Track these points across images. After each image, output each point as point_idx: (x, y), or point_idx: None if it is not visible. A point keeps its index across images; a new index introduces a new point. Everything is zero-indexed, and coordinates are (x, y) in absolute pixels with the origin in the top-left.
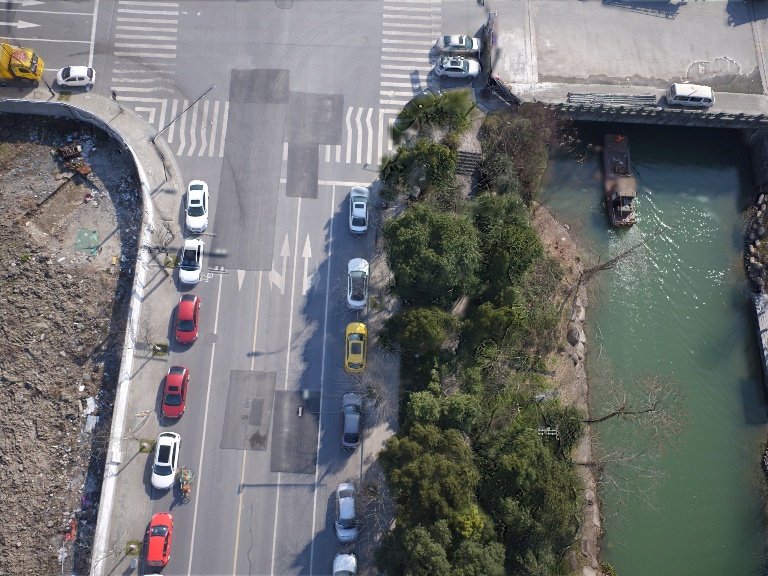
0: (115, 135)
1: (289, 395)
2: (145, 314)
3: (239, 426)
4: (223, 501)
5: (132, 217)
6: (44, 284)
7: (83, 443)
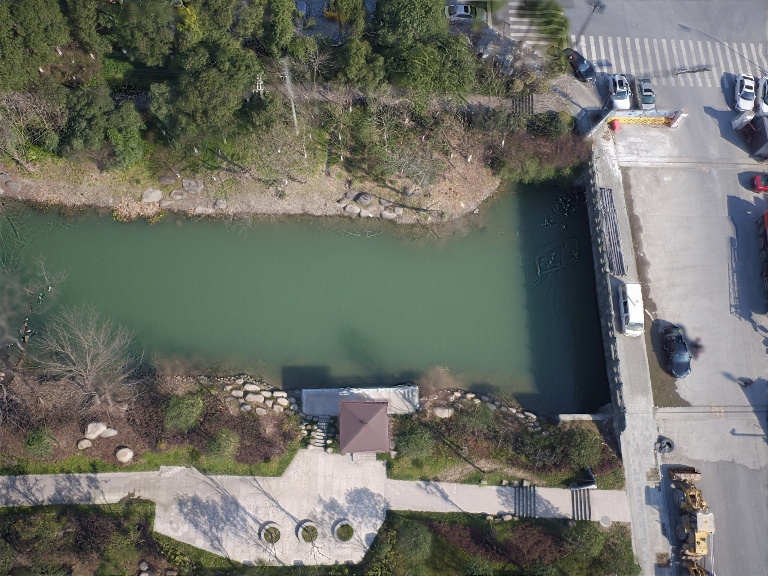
0: None
1: None
2: None
3: None
4: None
5: None
6: None
7: None
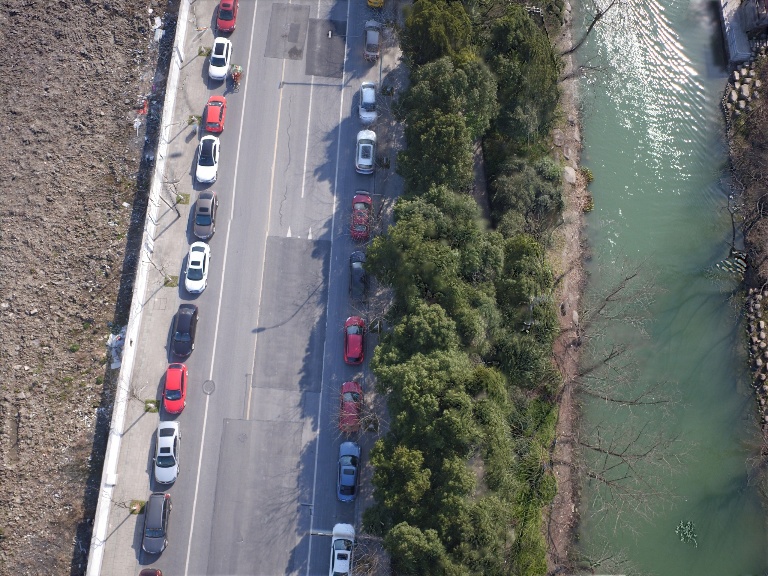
0: None
1: (321, 22)
2: None
3: (280, 42)
4: (267, 93)
5: None
6: None
7: (152, 49)
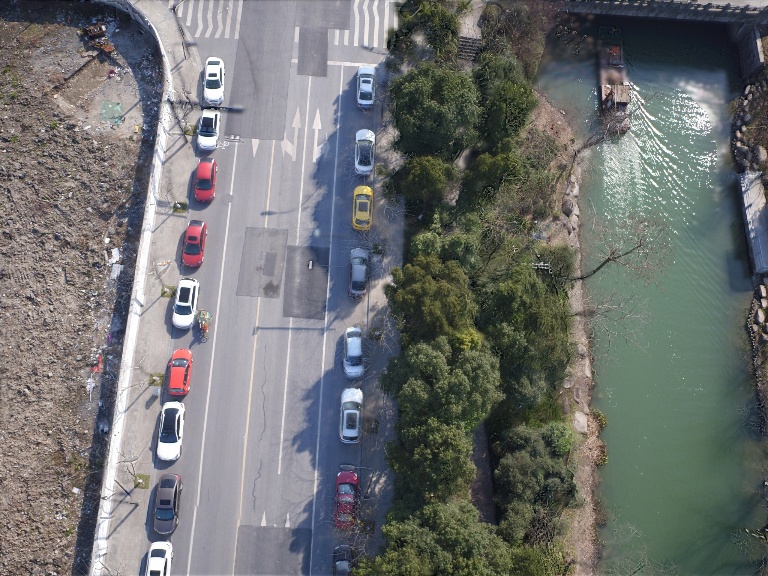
0: (137, 16)
1: (300, 250)
2: (166, 176)
3: (254, 276)
4: (239, 341)
5: (153, 91)
6: (71, 149)
7: (109, 289)
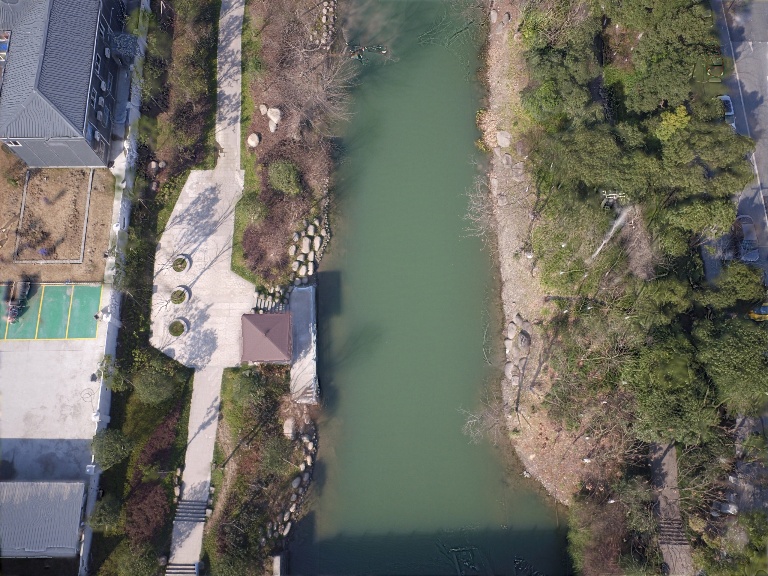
0: None
1: None
2: None
3: None
4: None
5: None
6: None
7: None
